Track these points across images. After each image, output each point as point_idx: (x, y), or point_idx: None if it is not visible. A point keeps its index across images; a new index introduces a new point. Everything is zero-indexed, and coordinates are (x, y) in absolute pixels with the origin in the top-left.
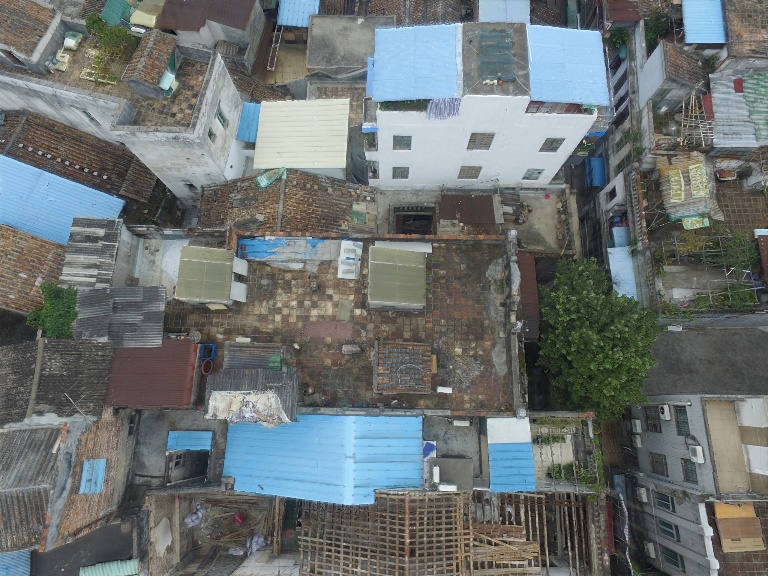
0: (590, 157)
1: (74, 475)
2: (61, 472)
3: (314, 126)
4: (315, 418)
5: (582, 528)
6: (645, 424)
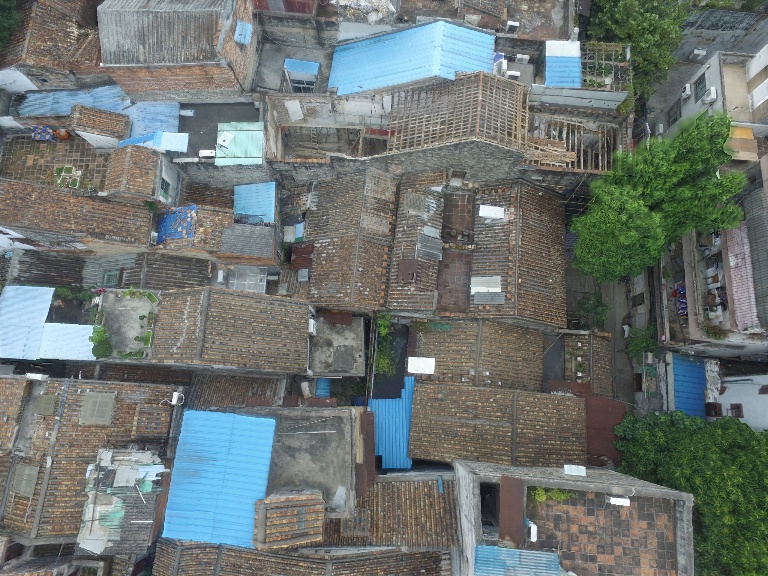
0: None
1: (233, 19)
2: (229, 2)
3: None
4: (410, 31)
5: (612, 149)
6: (667, 125)
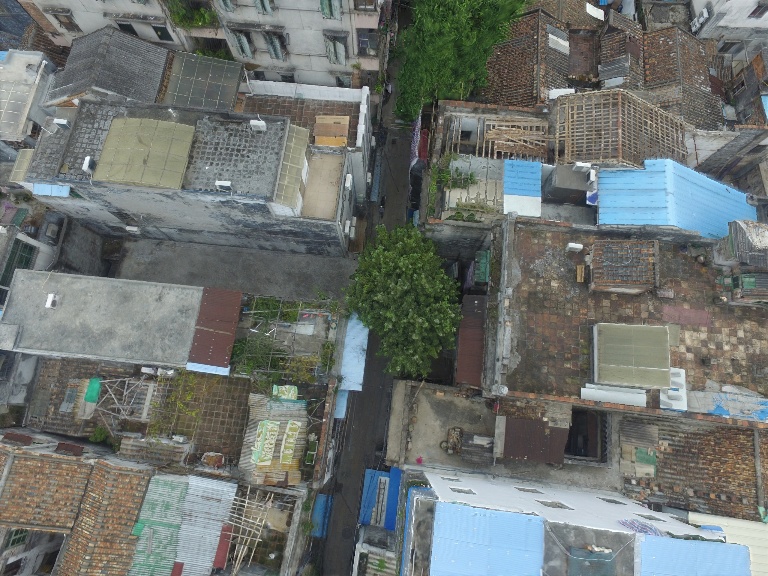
0: (322, 535)
1: None
2: None
3: None
4: None
5: None
6: None
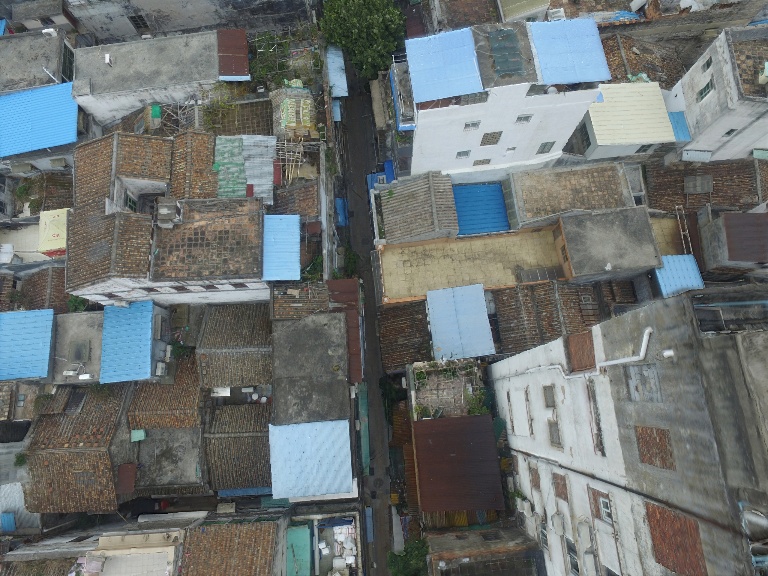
0: None
1: None
2: None
3: (621, 120)
4: None
5: None
6: None
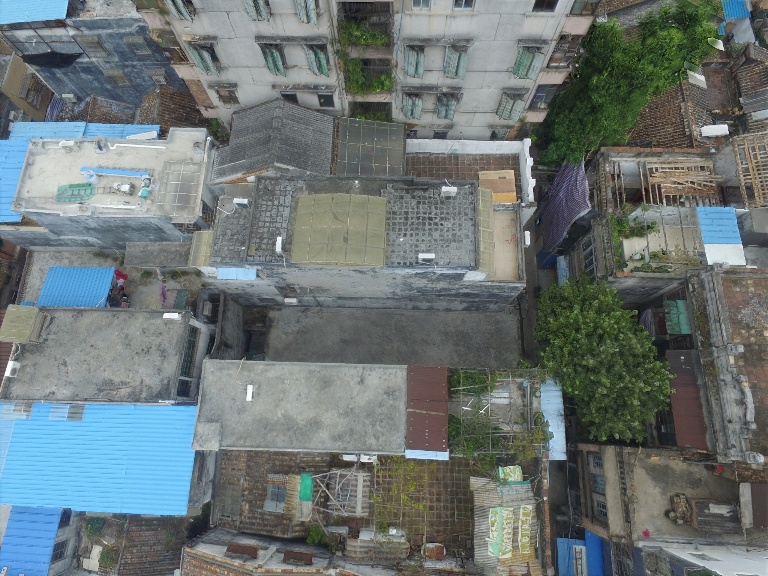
0: None
1: None
2: None
3: None
4: None
5: None
6: None
